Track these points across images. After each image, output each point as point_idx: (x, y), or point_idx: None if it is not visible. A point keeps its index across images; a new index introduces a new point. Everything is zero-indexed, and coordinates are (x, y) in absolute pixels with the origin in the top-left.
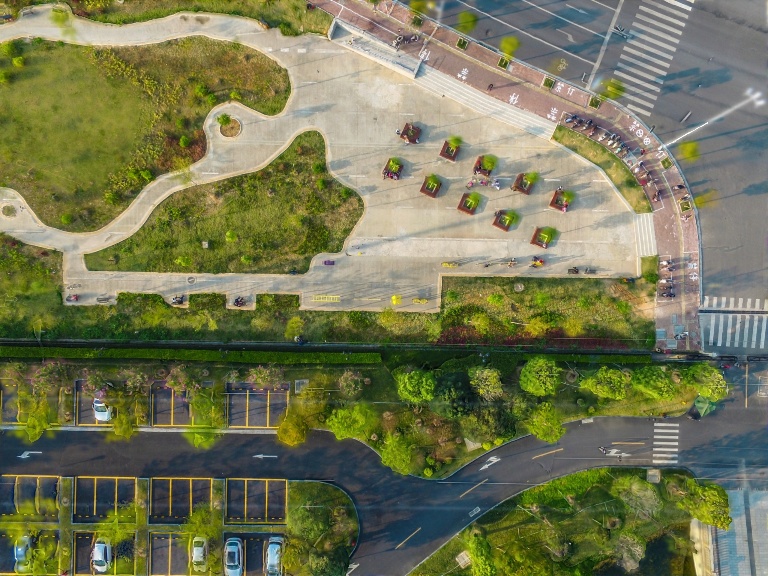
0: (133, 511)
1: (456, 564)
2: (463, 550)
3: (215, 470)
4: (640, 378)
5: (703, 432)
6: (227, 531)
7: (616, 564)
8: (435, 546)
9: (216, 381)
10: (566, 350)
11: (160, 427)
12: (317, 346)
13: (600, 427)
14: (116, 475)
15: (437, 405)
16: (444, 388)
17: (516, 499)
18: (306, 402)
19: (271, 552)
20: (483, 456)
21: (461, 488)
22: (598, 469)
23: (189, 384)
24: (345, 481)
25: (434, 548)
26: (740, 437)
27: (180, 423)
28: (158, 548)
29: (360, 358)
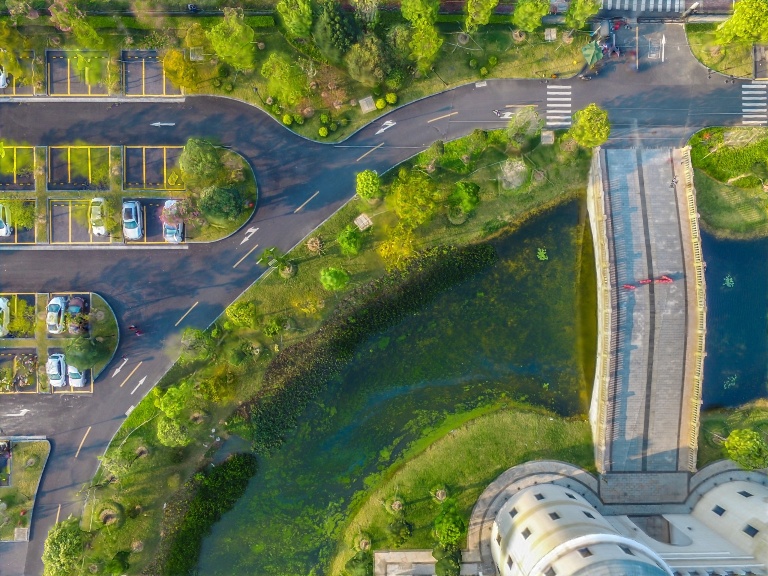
0: (32, 178)
1: (354, 226)
2: (361, 213)
3: (113, 138)
4: (519, 2)
5: (595, 93)
6: (126, 197)
7: (515, 233)
8: (333, 209)
9: (111, 48)
10: (457, 12)
11: (57, 97)
12: (211, 13)
13: (494, 90)
14: (15, 145)
15: (318, 28)
16: (322, 4)
17: (412, 160)
18: (190, 33)
19: (167, 206)
20: (379, 120)
21: (358, 152)
22: (492, 130)
23: (71, 10)
24: (242, 147)
25: (332, 211)
26: (632, 97)
27: (77, 92)
28: (58, 215)
29: (253, 21)
